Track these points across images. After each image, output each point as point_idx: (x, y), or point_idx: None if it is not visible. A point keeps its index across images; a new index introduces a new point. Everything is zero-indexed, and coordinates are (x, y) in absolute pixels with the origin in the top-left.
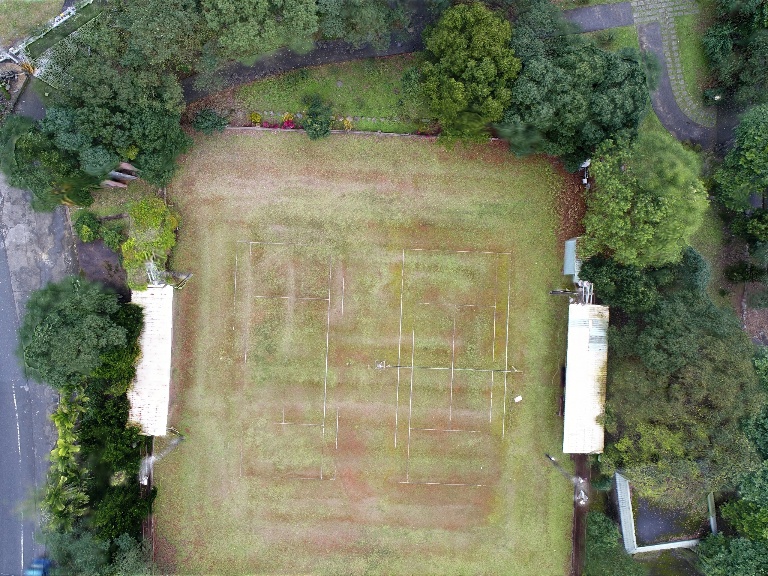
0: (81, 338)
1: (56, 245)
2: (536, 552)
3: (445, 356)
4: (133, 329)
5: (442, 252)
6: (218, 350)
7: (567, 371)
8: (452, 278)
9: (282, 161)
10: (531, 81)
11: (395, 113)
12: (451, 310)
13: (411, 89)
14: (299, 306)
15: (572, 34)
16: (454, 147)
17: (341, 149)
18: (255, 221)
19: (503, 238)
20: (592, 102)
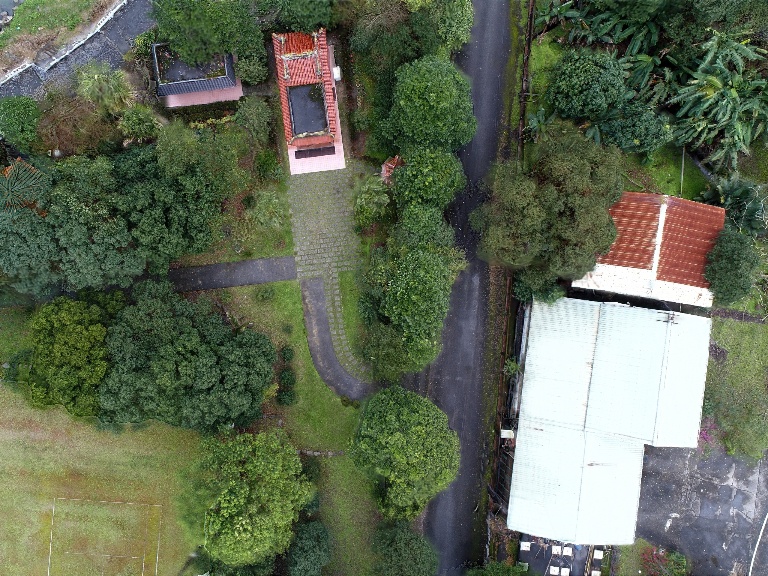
0: None
1: None
2: None
3: None
4: None
5: (93, 502)
6: None
7: None
8: (102, 529)
9: None
10: (108, 392)
11: None
12: (99, 560)
13: None
14: None
15: (235, 286)
16: None
17: None
18: None
19: (155, 490)
20: (181, 406)
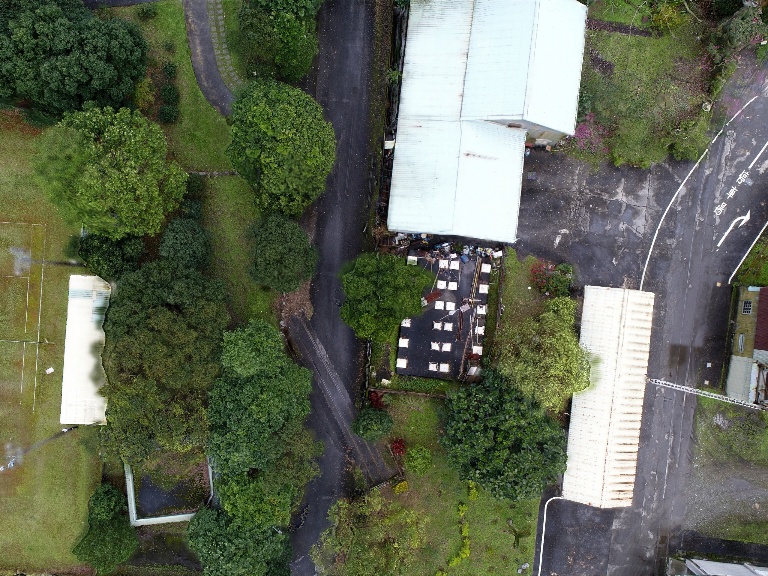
0: None
1: None
2: (64, 524)
3: None
4: None
5: None
6: None
7: (66, 342)
8: None
9: None
10: None
11: None
12: None
13: None
14: None
15: (117, 7)
16: None
17: None
18: None
19: (38, 209)
20: None
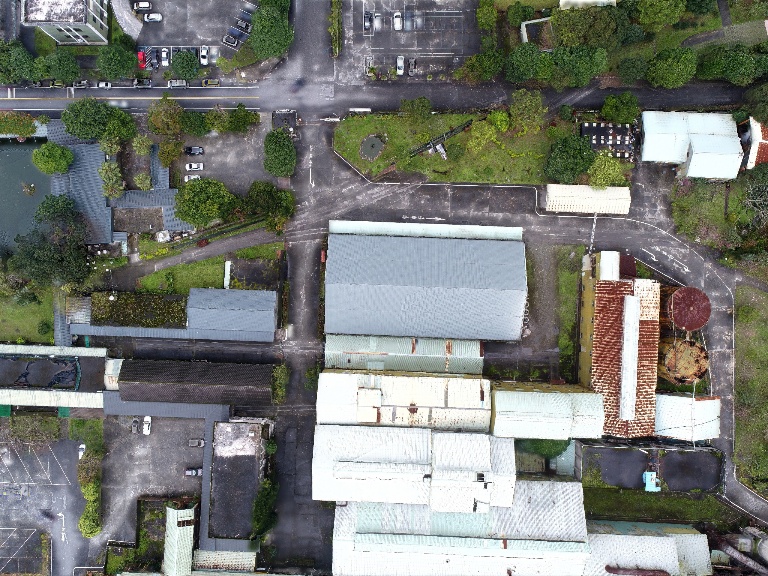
0: None
1: None
2: None
3: None
4: None
5: None
6: None
7: None
8: None
9: None
10: None
11: None
12: None
13: None
14: None
15: (717, 2)
16: None
17: None
18: None
19: None
20: None
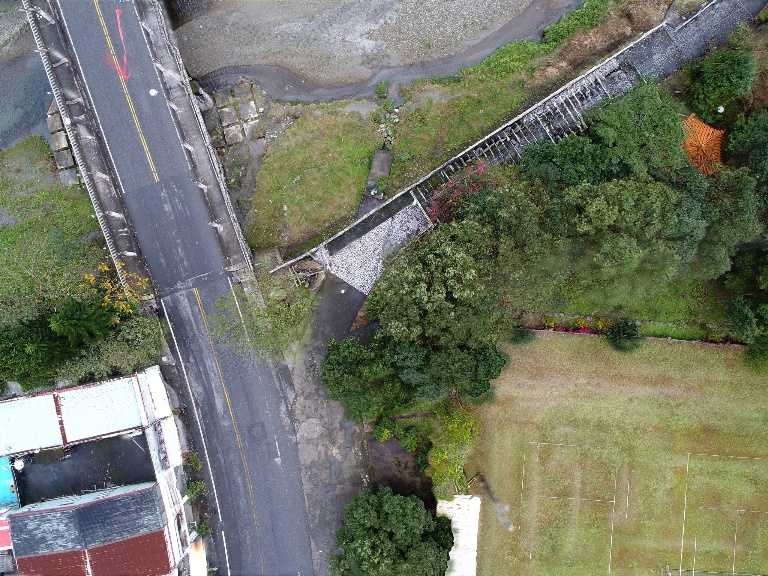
0: (421, 570)
1: (347, 440)
2: None
3: (726, 561)
4: (450, 546)
5: (726, 458)
6: (504, 549)
7: None
8: (735, 484)
9: (572, 363)
10: None
11: (682, 318)
12: (733, 515)
13: (698, 294)
14: (584, 507)
15: None
16: (741, 354)
17: (630, 353)
18: (544, 422)
19: None
20: None
